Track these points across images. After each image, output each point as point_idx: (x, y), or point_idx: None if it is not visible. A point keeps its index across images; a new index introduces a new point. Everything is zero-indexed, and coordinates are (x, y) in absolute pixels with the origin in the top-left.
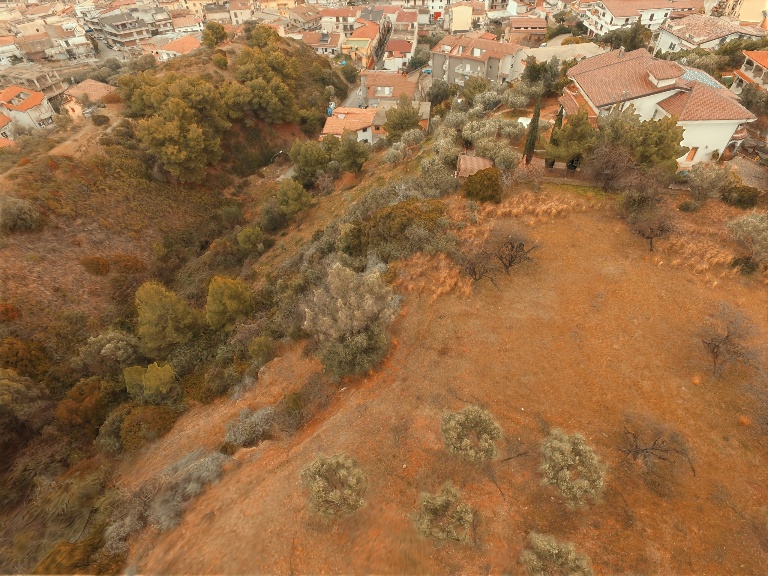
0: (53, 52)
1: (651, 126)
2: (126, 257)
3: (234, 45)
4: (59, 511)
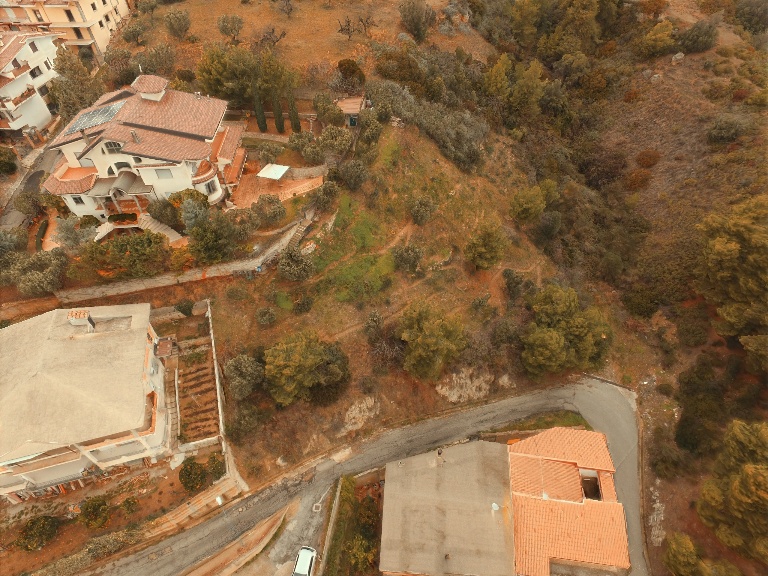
0: None
1: (222, 58)
2: (642, 177)
3: None
4: None
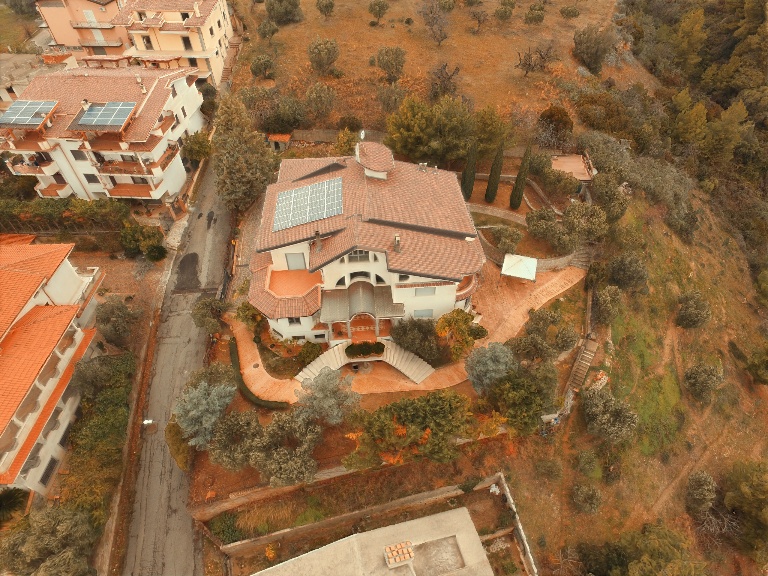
0: None
1: (423, 110)
2: None
3: None
4: (659, 54)
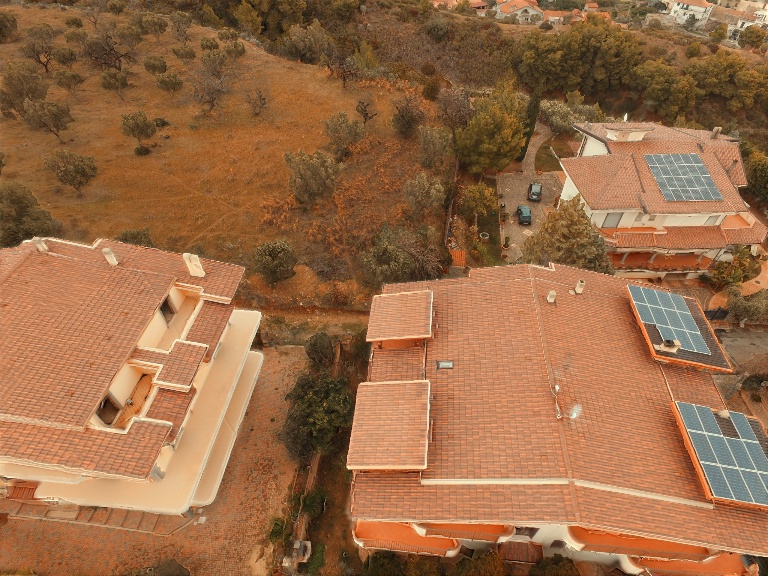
0: (731, 28)
1: None
2: None
3: (750, 54)
4: None
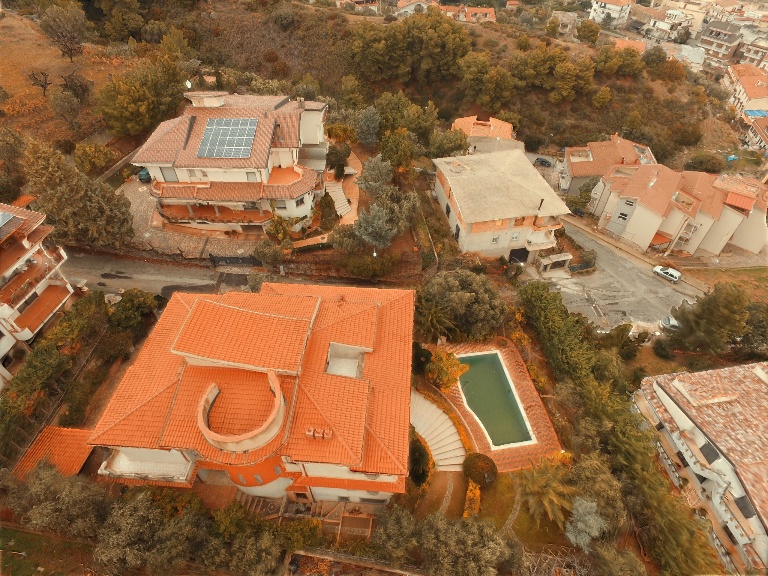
0: None
1: None
2: (283, 65)
3: (584, 48)
4: None
